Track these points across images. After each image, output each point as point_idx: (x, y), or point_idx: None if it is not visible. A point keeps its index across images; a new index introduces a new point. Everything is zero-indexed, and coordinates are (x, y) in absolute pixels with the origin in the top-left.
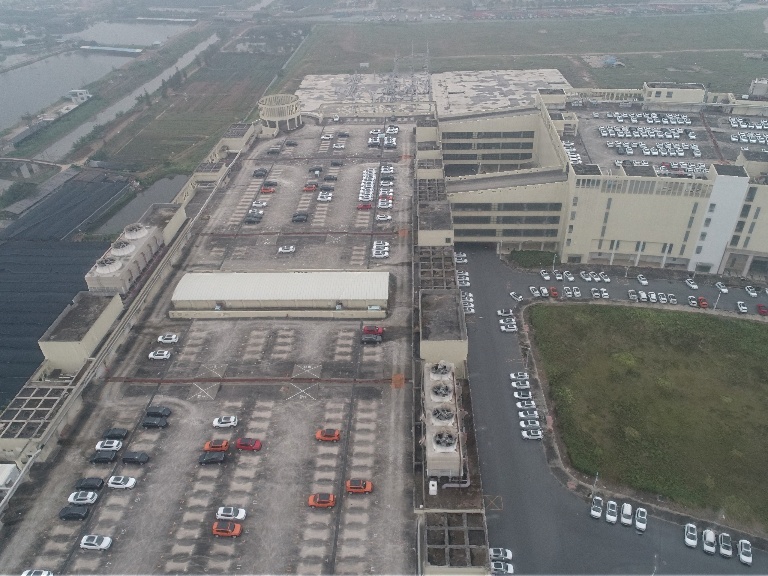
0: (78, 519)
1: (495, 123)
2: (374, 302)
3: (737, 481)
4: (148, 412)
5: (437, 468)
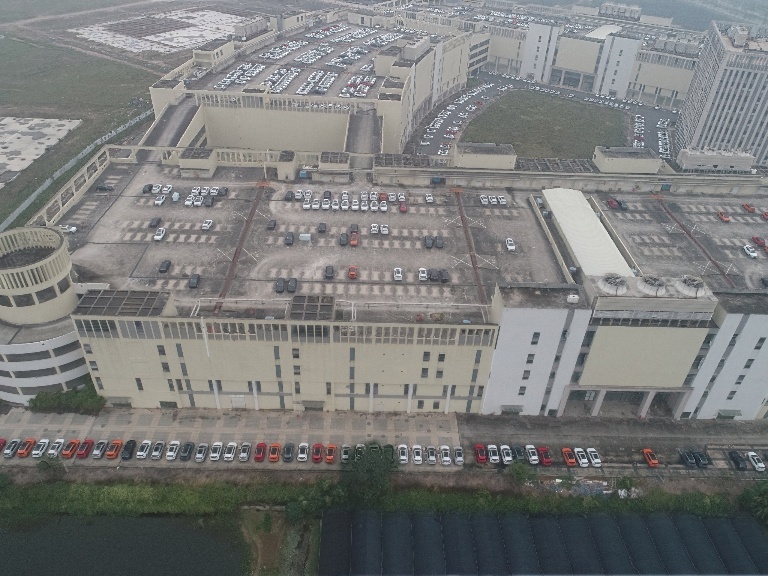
0: None
1: (190, 131)
2: None
3: None
4: None
5: None
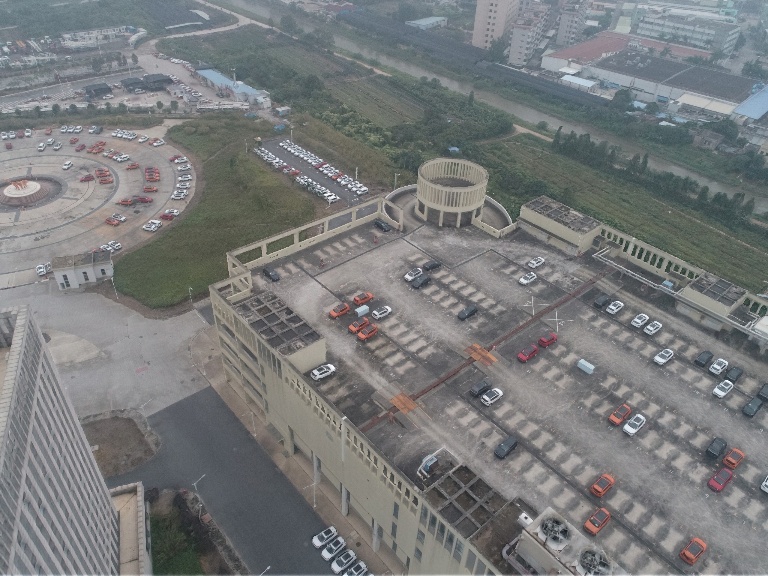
0: None
1: None
2: None
3: None
4: None
5: None
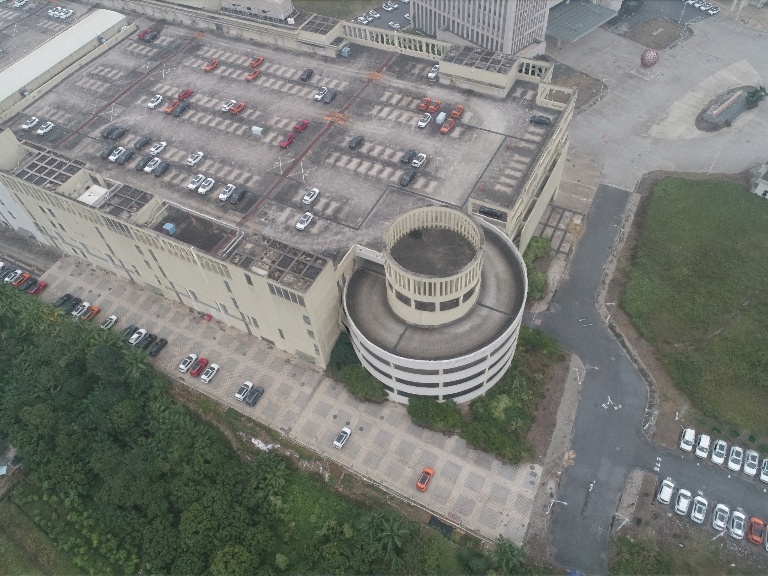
0: (168, 168)
1: None
2: (119, 25)
3: (346, 1)
4: (106, 133)
5: (285, 11)
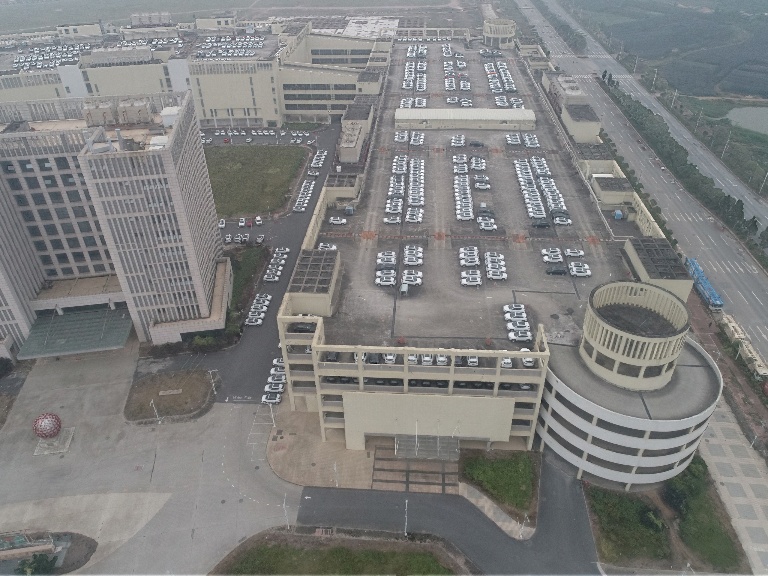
0: None
1: None
2: None
3: None
4: None
5: None
